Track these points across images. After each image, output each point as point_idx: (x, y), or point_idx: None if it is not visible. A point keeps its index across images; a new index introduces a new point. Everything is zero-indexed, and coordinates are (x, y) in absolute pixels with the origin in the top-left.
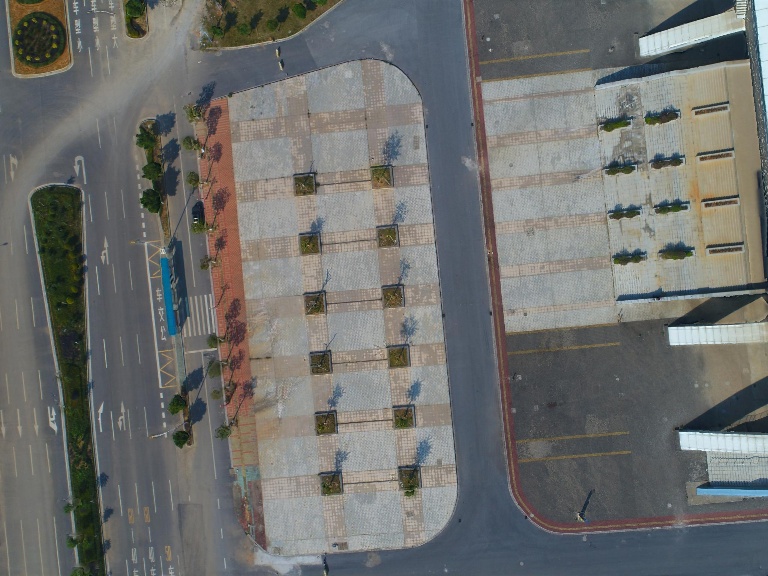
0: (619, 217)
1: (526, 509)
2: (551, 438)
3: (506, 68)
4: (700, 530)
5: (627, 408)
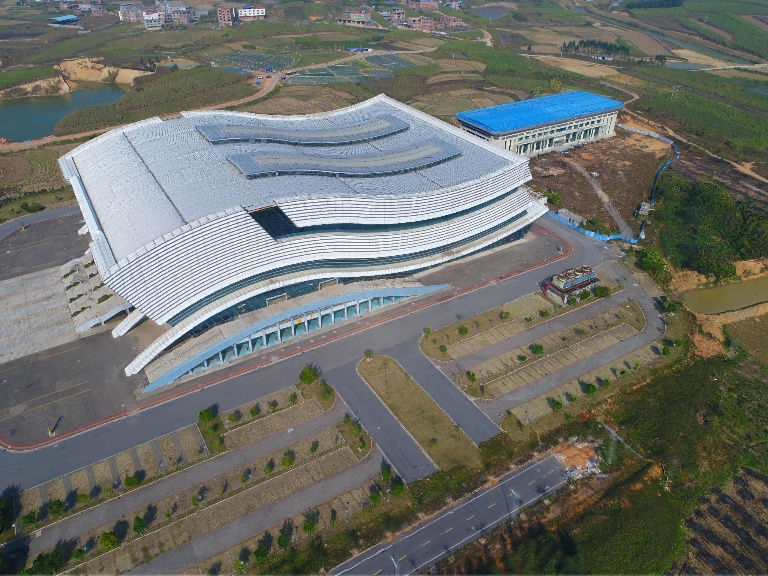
0: (72, 299)
1: (4, 445)
2: (28, 401)
3: (7, 276)
4: (149, 411)
5: (86, 371)
